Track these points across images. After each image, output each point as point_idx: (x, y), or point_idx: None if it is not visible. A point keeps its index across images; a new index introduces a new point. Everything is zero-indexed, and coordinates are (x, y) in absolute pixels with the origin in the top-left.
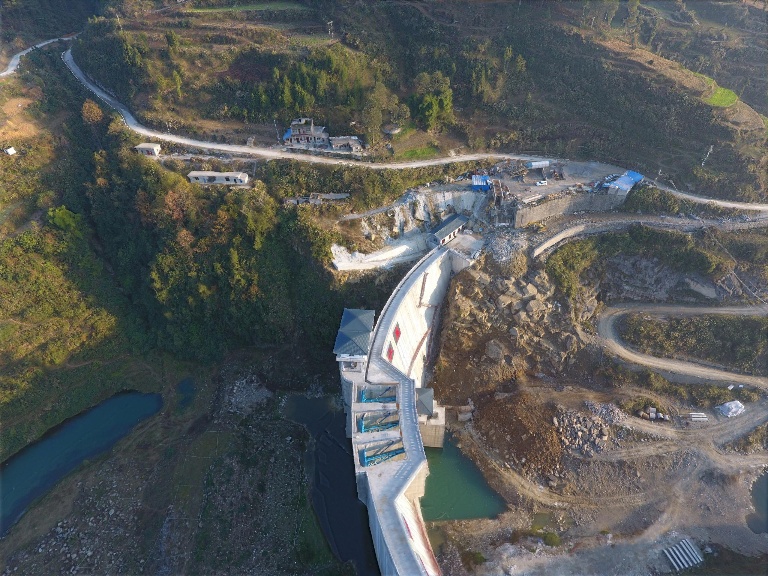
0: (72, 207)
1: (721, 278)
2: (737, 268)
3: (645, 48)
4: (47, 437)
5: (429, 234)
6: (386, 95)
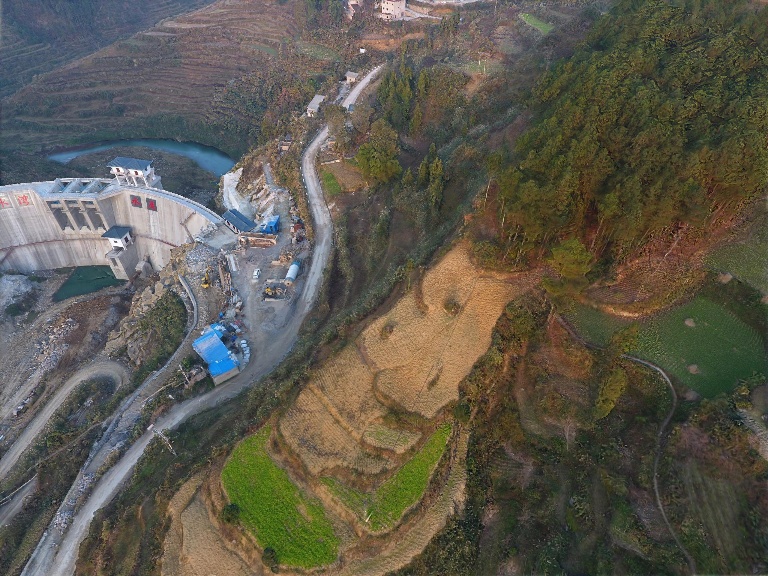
0: None
1: None
2: (34, 493)
3: (491, 351)
4: None
5: None
6: None
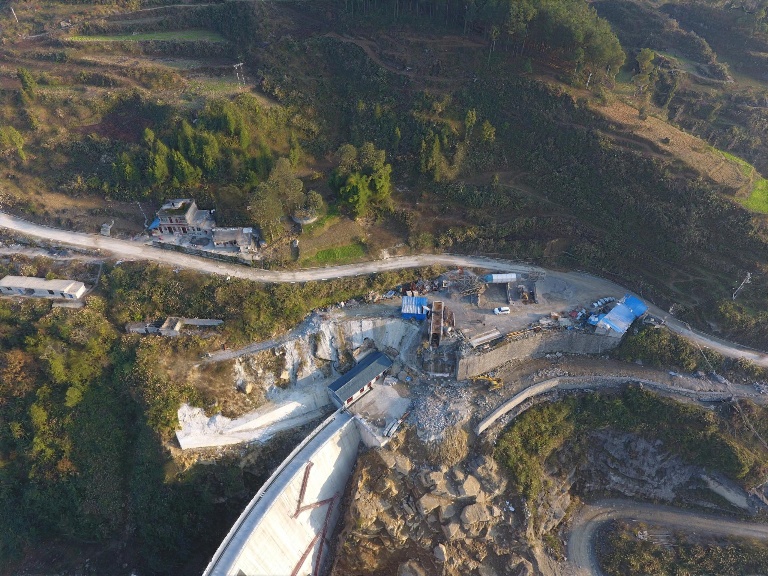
0: None
1: (756, 485)
2: None
3: (659, 116)
4: None
5: (329, 389)
6: (305, 166)
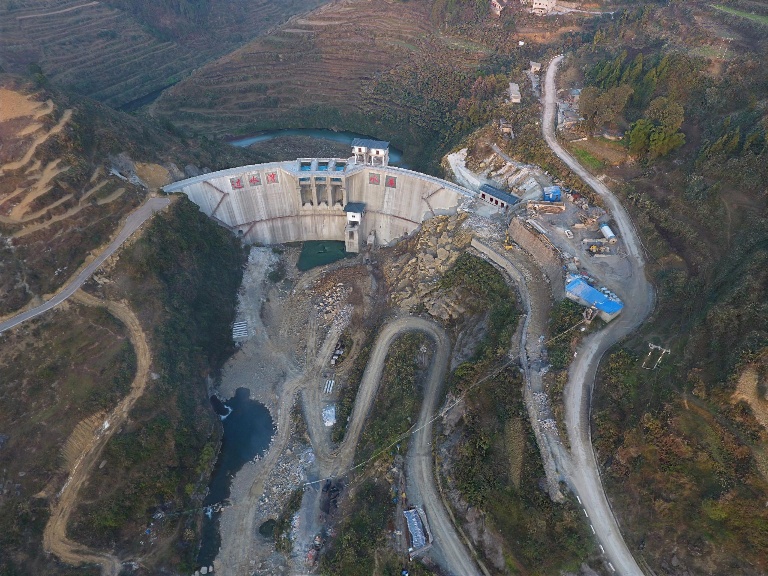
0: None
1: None
2: (468, 412)
3: None
4: None
5: None
6: None
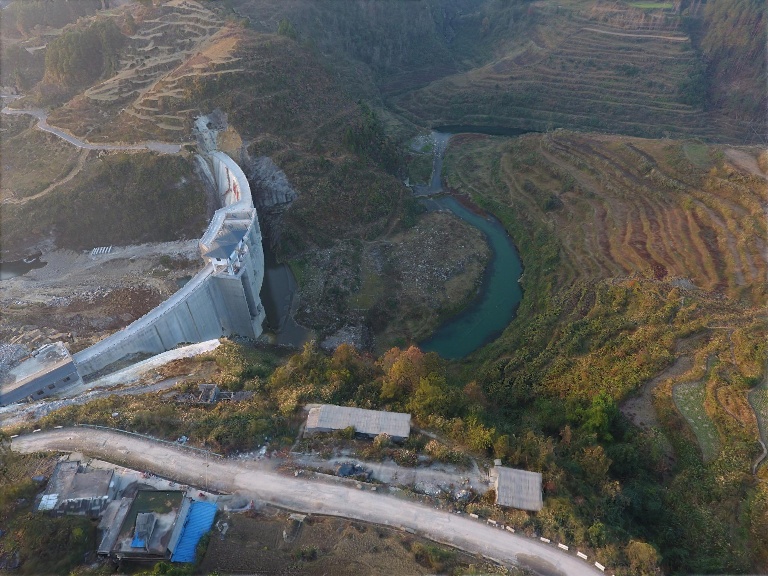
0: None
1: None
2: None
3: None
4: (498, 331)
5: None
6: None
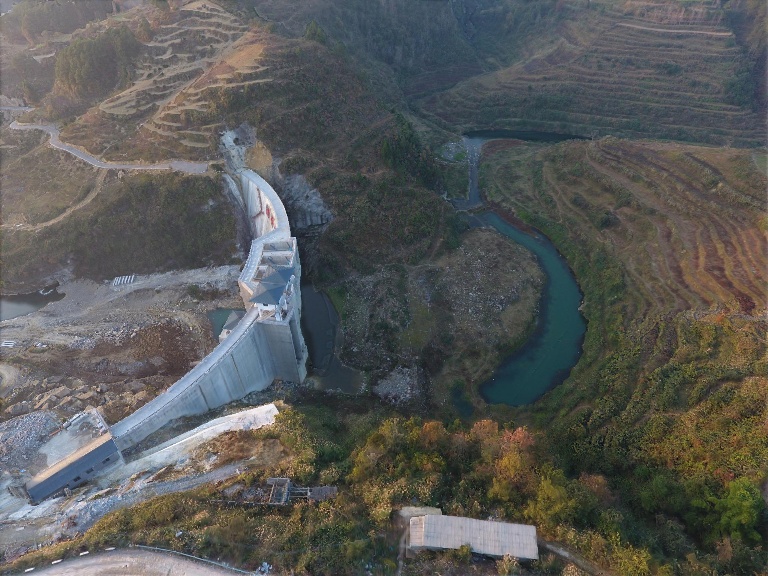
0: (767, 552)
1: None
2: None
3: None
4: (565, 370)
5: None
6: None
